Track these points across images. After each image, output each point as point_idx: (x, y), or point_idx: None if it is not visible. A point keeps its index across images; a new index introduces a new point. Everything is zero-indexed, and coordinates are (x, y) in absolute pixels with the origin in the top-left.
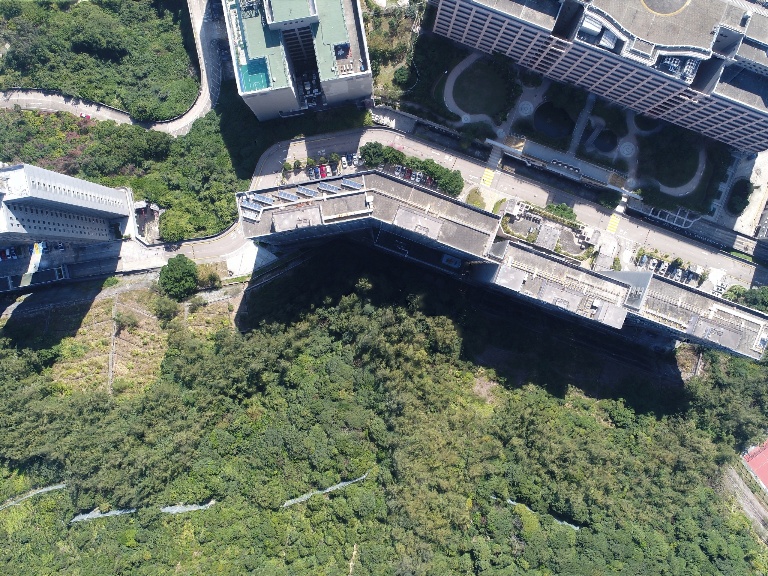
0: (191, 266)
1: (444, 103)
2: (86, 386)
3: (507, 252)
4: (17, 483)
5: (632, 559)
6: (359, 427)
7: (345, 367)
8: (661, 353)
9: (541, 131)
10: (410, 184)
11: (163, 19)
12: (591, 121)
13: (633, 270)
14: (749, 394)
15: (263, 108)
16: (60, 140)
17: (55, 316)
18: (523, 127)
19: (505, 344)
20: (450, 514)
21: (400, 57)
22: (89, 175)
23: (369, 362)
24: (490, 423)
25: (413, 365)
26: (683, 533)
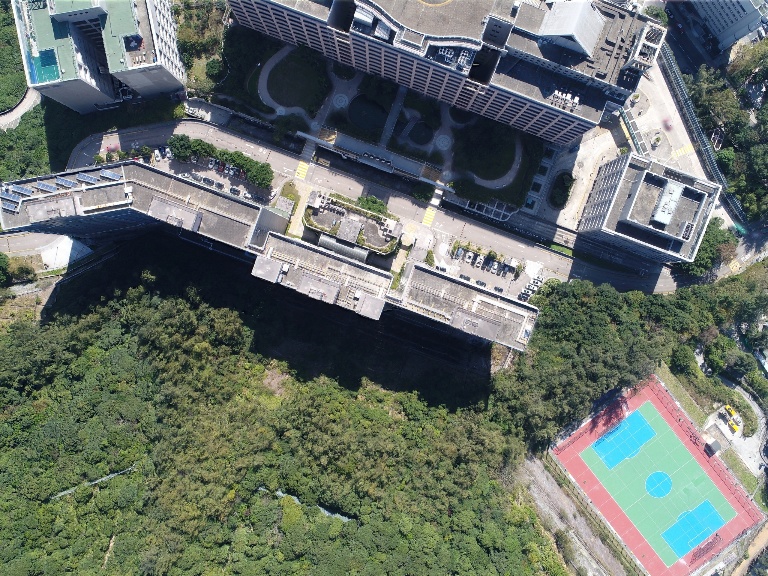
0: (1, 259)
1: (258, 96)
2: None
3: (268, 243)
4: None
5: (396, 551)
6: (133, 419)
7: (127, 359)
8: (478, 346)
9: (351, 123)
10: (169, 175)
11: None
12: (406, 114)
13: (449, 263)
14: (543, 387)
15: (71, 100)
16: None
17: None
18: (337, 120)
19: (303, 337)
20: (205, 505)
21: (213, 49)
22: None
23: (149, 354)
24: (273, 415)
25: (194, 357)
26: (457, 525)
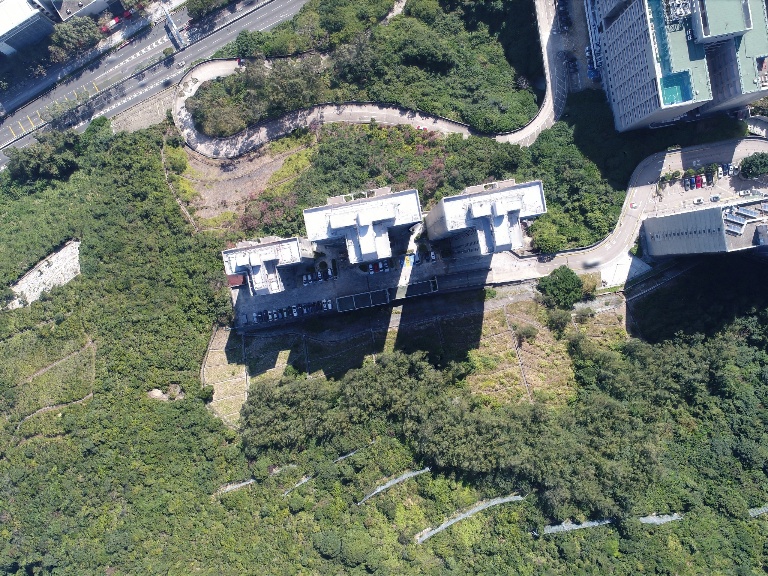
0: None
1: None
2: (509, 398)
3: None
4: (463, 495)
5: None
6: None
7: None
8: None
9: None
10: None
11: (472, 31)
12: None
13: None
14: None
15: (648, 120)
16: (408, 153)
17: (447, 328)
18: None
19: None
20: None
21: None
22: (456, 188)
23: None
24: None
25: None
26: None
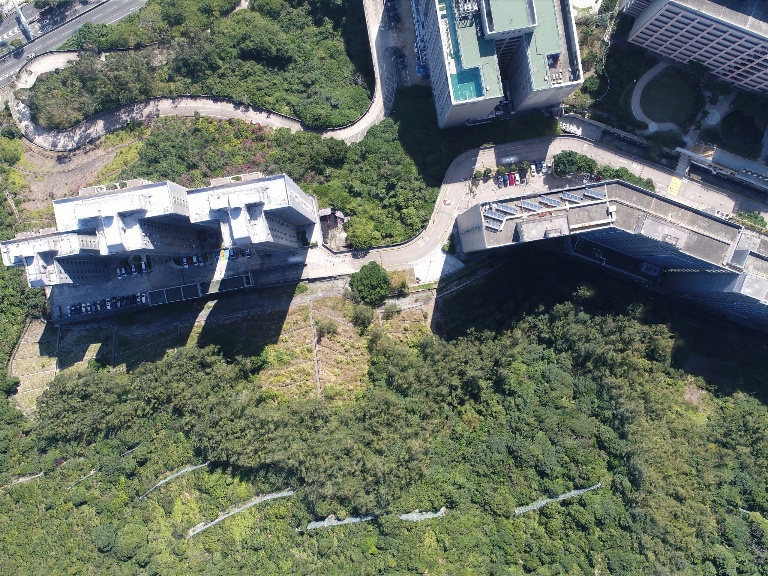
0: (384, 273)
1: (631, 111)
2: (298, 393)
3: (746, 261)
4: (239, 490)
5: None
6: (587, 435)
7: (564, 375)
8: None
9: (732, 140)
10: (652, 194)
11: (319, 26)
12: None
13: None
14: None
15: (457, 116)
16: (235, 147)
17: (251, 323)
18: (710, 135)
19: (708, 352)
20: (696, 522)
21: (588, 66)
22: None
23: (591, 370)
24: (708, 431)
25: None
26: None
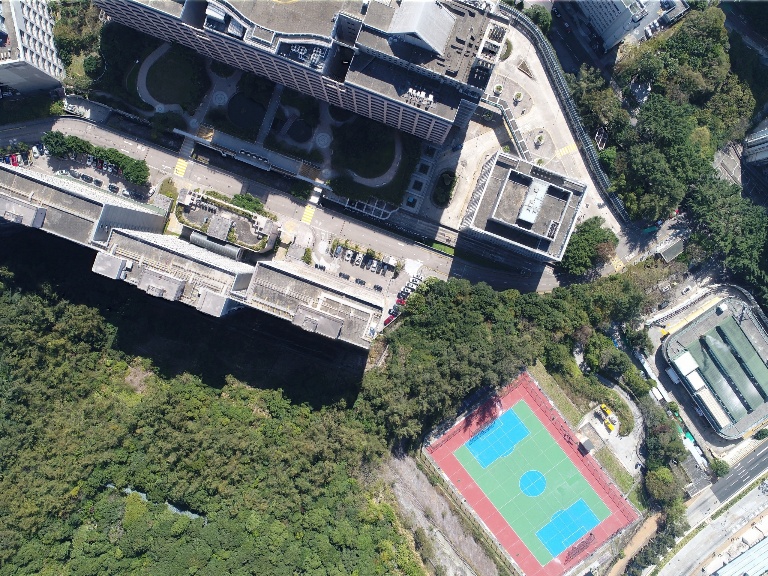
0: None
1: (137, 93)
2: None
3: (113, 240)
4: None
5: (240, 548)
6: None
7: None
8: None
9: (228, 121)
10: (12, 171)
11: None
12: (286, 111)
13: (329, 261)
14: (407, 385)
15: None
16: None
17: None
18: (216, 117)
19: (171, 334)
20: (44, 502)
21: (92, 46)
22: None
23: (4, 350)
24: (130, 412)
25: (51, 354)
26: (307, 523)
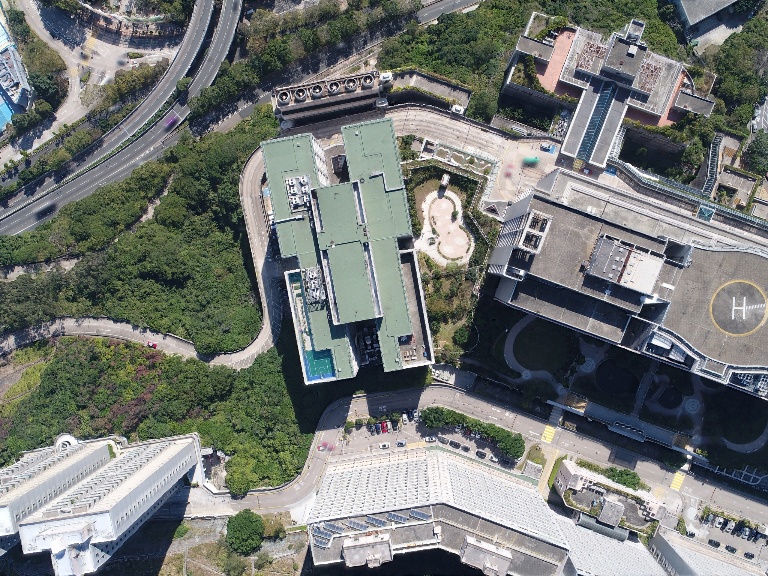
0: (257, 522)
1: (504, 360)
2: None
3: None
4: None
5: None
6: None
7: None
8: None
9: (604, 394)
10: (478, 515)
11: (223, 232)
12: (655, 378)
13: (698, 527)
14: None
15: None
16: (130, 374)
17: (130, 571)
18: (585, 385)
19: None
20: None
21: (460, 315)
22: (158, 421)
23: None
24: None
25: None
26: None
